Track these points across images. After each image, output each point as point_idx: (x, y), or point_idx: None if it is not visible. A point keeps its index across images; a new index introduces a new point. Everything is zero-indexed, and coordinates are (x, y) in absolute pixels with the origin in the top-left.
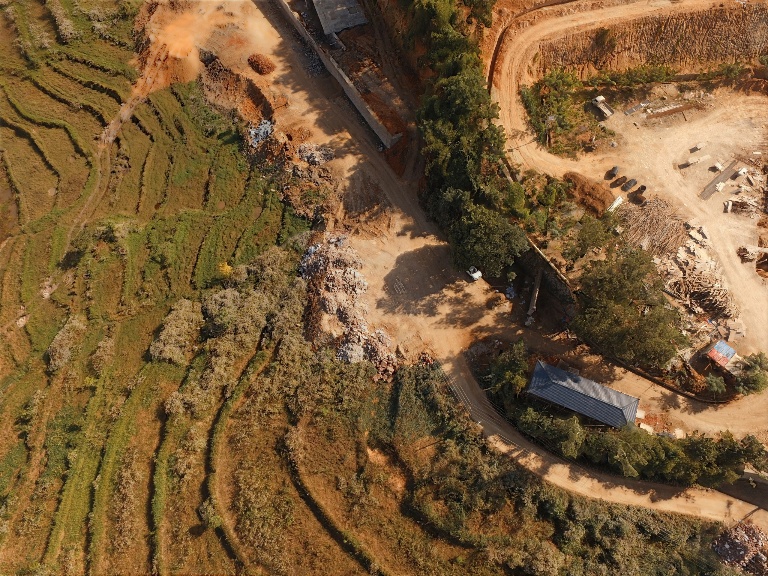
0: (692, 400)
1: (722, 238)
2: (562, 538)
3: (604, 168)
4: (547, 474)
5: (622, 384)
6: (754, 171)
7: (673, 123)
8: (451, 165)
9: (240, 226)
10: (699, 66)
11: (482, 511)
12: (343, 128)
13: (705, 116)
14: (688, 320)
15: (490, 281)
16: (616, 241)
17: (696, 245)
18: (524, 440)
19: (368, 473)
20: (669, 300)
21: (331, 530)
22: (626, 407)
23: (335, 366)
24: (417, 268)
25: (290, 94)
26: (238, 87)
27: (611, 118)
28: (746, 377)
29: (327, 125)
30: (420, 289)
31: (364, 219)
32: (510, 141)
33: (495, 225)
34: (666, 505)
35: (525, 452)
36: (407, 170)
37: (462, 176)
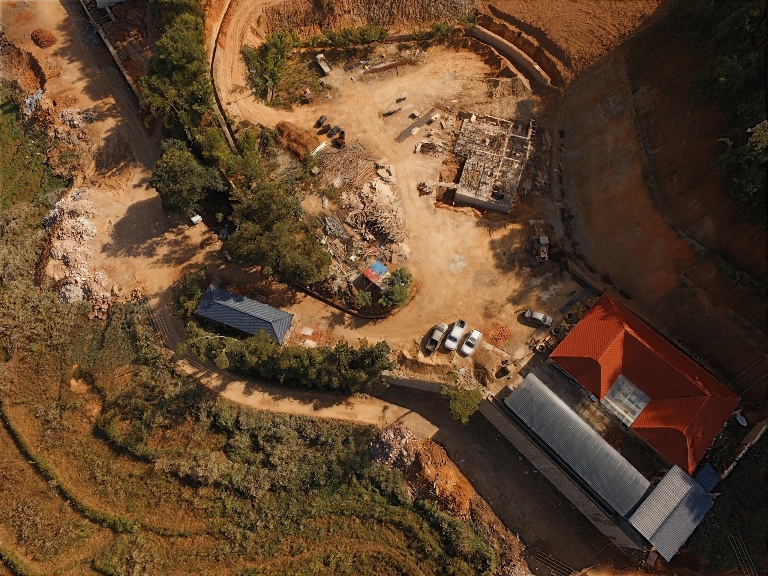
0: (356, 317)
1: (407, 175)
2: (229, 447)
3: (315, 118)
4: (224, 391)
5: (300, 307)
6: (448, 117)
7: (386, 77)
8: (172, 118)
9: (2, 187)
10: (416, 27)
11: (163, 428)
12: (109, 94)
13: (416, 71)
14: (360, 246)
15: (209, 224)
16: (312, 181)
17: (381, 182)
18: (210, 362)
19: (64, 400)
20: (347, 230)
21: (26, 455)
22: (276, 321)
23: (51, 306)
24: (145, 215)
25: (65, 65)
26: (21, 60)
27: (332, 74)
28: (387, 290)
29: (94, 92)
30: (144, 234)
31: (108, 174)
32: (229, 95)
33: (173, 163)
34: (326, 412)
35: (208, 373)
36: (156, 129)
37: (180, 127)
